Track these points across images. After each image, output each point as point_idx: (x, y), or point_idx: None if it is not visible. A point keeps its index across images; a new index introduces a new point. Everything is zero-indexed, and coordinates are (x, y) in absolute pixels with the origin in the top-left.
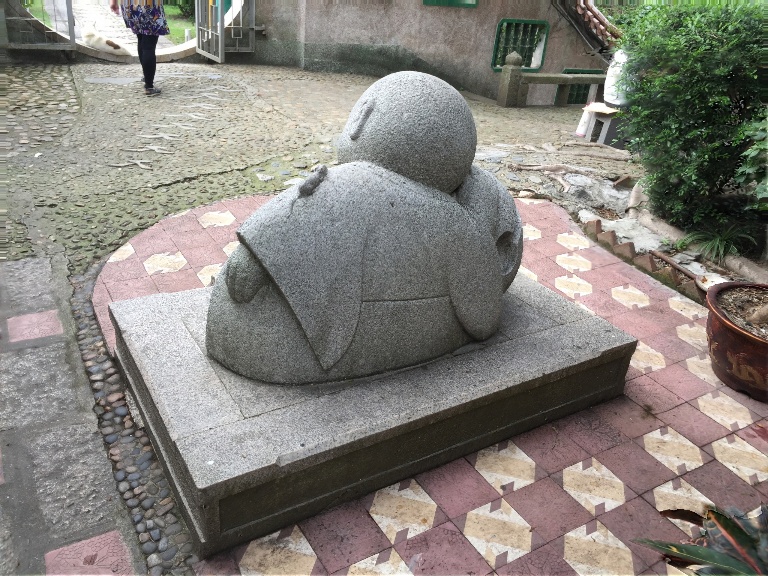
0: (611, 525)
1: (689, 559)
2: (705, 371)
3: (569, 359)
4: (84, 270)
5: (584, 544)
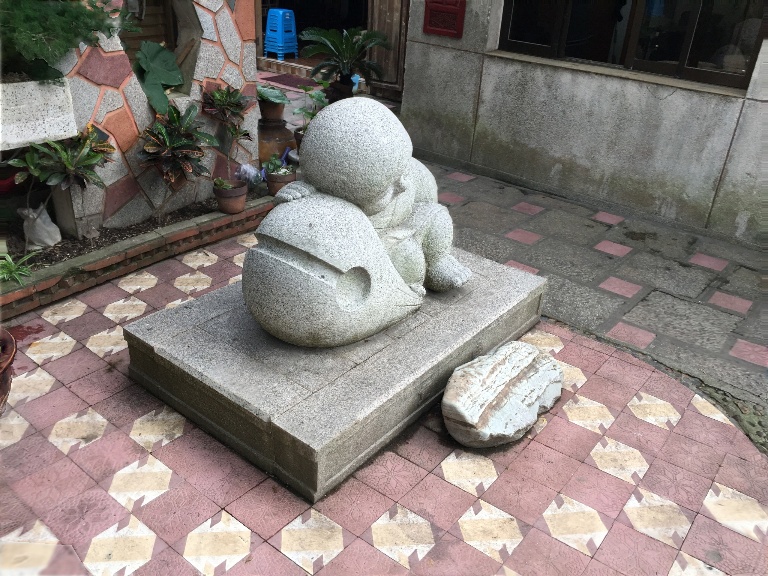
0: (181, 293)
1: (206, 133)
2: (8, 427)
3: (198, 297)
4: (709, 394)
5: (200, 284)
